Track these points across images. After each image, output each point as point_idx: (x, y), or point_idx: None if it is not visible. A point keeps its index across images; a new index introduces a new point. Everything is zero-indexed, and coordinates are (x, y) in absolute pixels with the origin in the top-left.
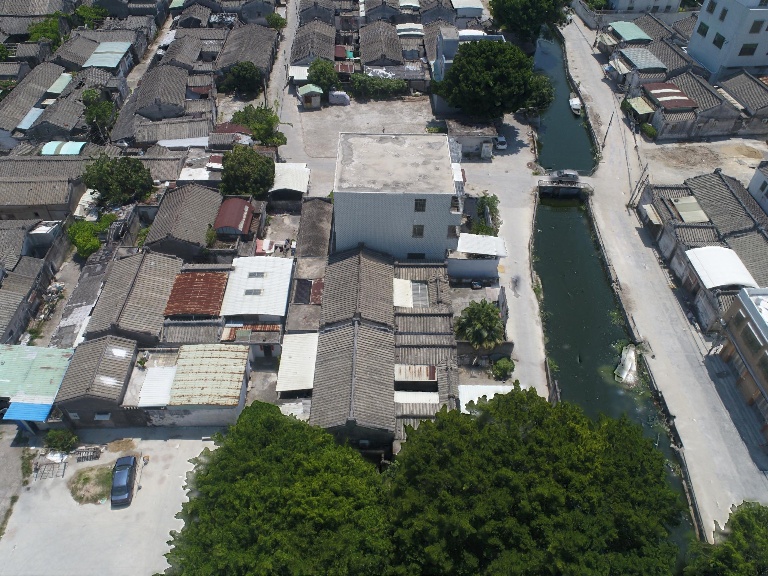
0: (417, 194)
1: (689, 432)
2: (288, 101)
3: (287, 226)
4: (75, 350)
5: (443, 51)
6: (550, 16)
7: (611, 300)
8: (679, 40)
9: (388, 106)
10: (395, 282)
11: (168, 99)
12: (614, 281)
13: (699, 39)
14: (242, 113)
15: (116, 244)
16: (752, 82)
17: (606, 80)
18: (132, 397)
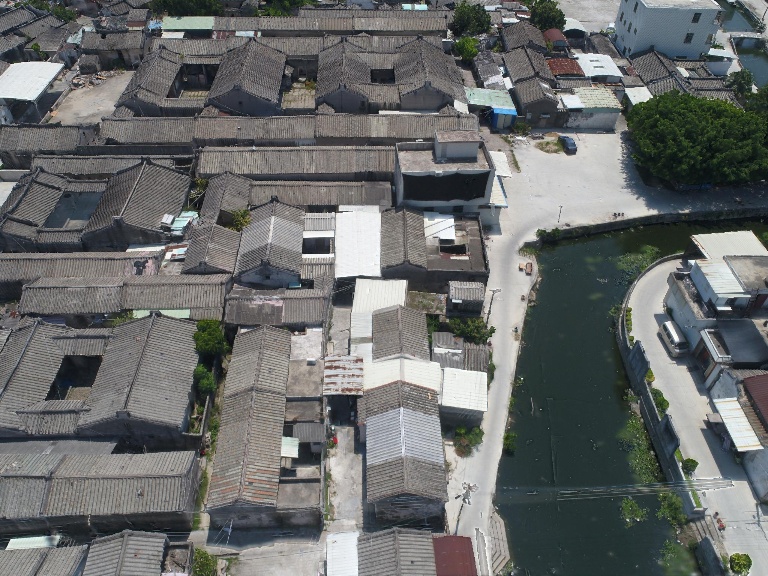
0: (697, 9)
1: None
2: None
3: None
4: None
5: None
6: None
7: None
8: None
9: None
10: (677, 68)
11: None
12: None
13: None
14: None
15: (489, 51)
16: None
17: None
18: (558, 107)
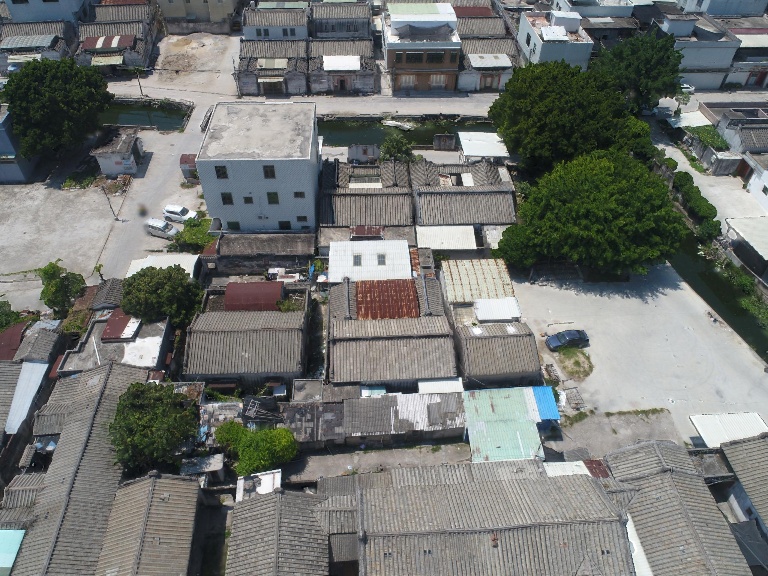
0: (313, 120)
1: (450, 111)
2: None
3: None
4: (474, 377)
5: None
6: None
7: (340, 123)
8: (5, 20)
9: None
10: None
11: None
12: (323, 117)
13: (23, 8)
14: None
15: (285, 407)
16: (112, 7)
17: None
18: None
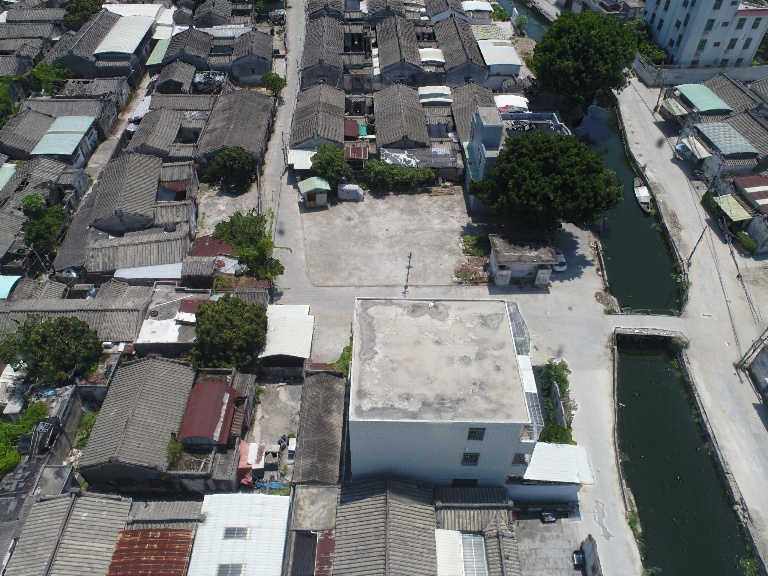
0: (473, 423)
1: None
2: (287, 196)
3: (283, 405)
4: None
5: (482, 139)
6: (608, 82)
7: (737, 536)
8: (766, 111)
9: (411, 202)
10: (438, 538)
11: (132, 207)
12: (738, 502)
13: None
14: (227, 225)
15: (41, 460)
16: None
17: (677, 160)
18: None
